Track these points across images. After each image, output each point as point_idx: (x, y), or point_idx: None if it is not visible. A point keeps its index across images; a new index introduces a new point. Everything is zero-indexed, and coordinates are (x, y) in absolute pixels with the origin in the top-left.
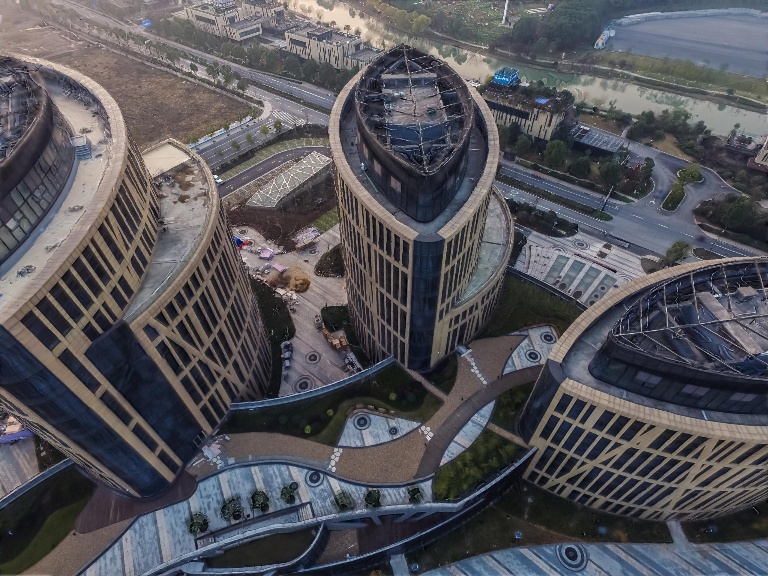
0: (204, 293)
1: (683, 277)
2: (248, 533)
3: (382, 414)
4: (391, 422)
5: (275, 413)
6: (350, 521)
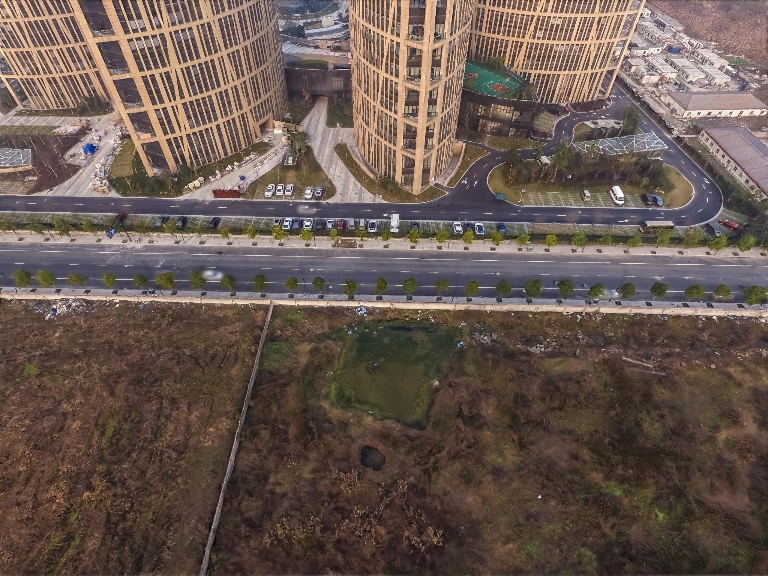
0: None
1: None
2: None
3: None
4: None
5: None
6: None
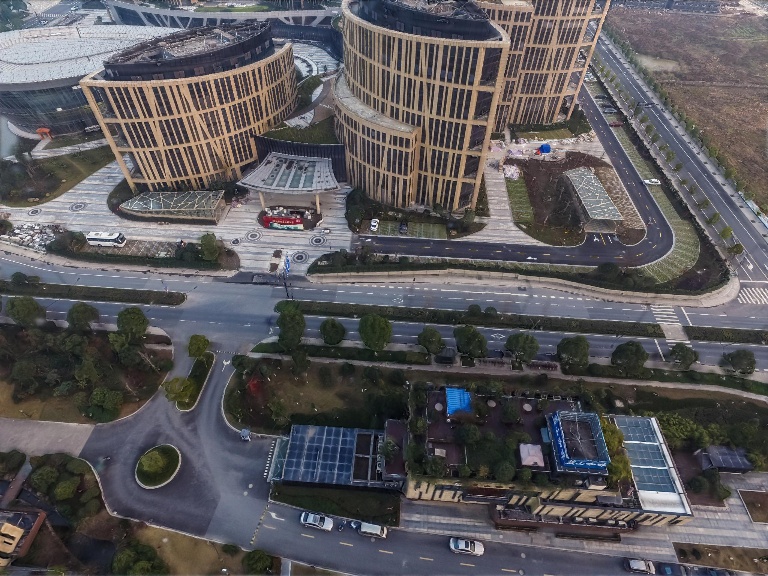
0: None
1: (241, 42)
2: None
3: None
4: None
5: None
6: None
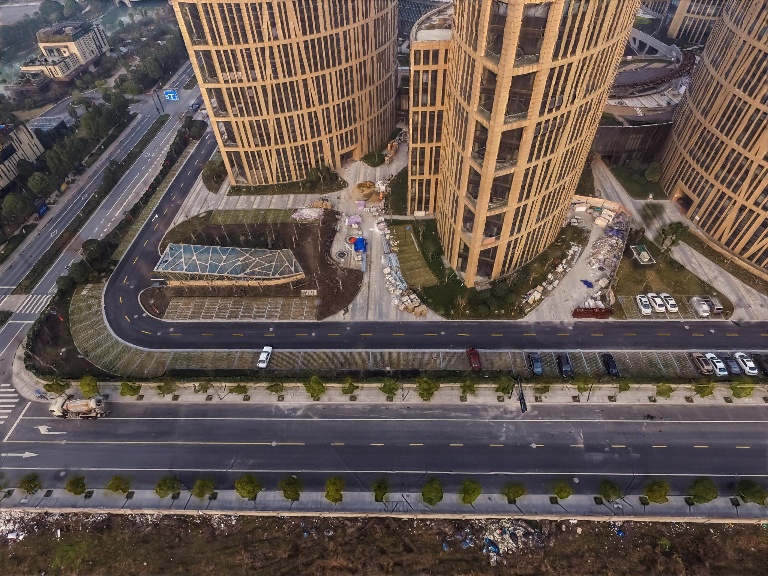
0: None
1: None
2: None
3: None
4: None
5: None
6: None
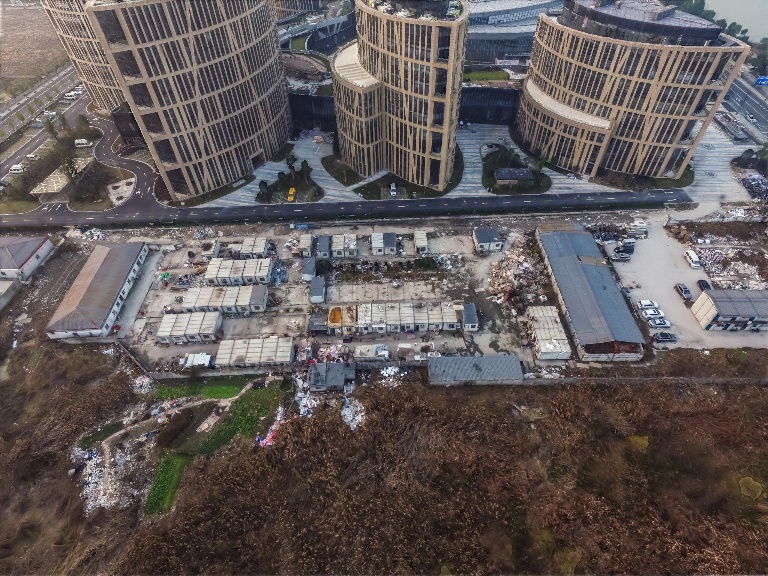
0: None
1: None
2: (301, 25)
3: (314, 15)
4: None
5: None
6: (322, 33)
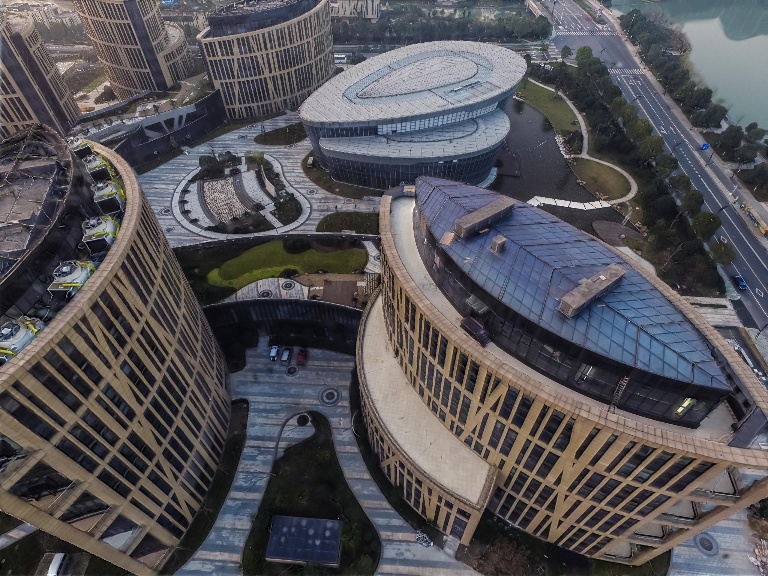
0: (42, 44)
1: (232, 4)
2: (109, 127)
3: (152, 101)
4: (157, 102)
5: (101, 114)
6: (154, 131)
